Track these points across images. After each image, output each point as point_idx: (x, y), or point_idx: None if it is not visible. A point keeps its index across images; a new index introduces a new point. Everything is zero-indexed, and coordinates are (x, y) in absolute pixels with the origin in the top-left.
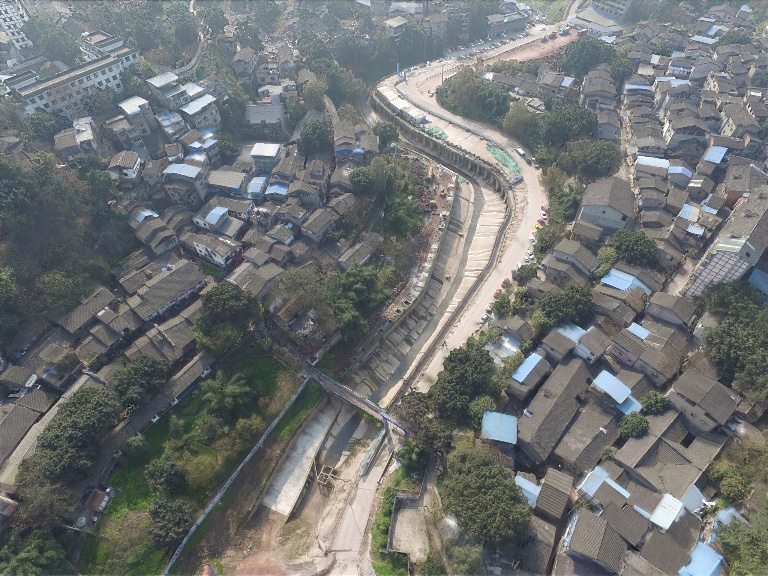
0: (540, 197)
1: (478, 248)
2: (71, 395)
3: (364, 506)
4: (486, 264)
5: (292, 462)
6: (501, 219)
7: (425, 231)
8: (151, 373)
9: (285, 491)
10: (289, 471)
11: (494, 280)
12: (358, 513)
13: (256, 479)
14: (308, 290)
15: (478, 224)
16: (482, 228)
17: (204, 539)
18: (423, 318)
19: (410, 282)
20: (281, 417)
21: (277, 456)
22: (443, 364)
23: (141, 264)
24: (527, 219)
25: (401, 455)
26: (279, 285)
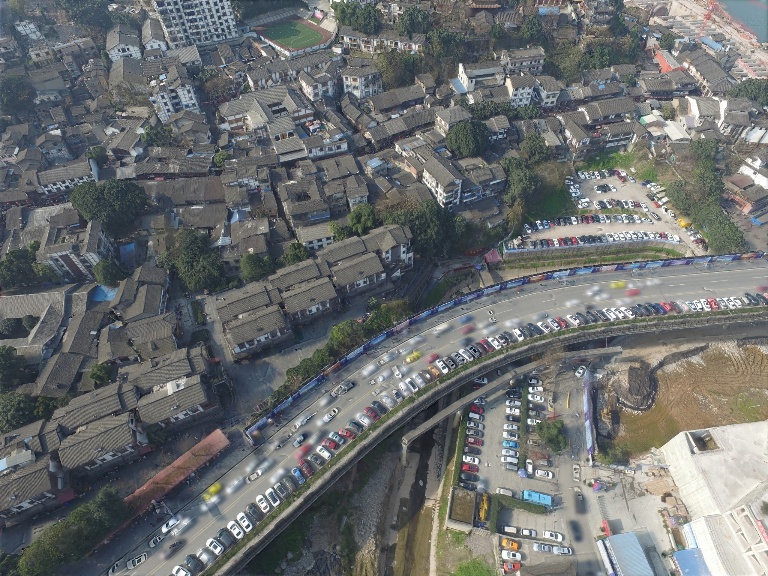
0: None
1: None
2: None
3: None
4: None
5: None
6: None
7: None
8: None
9: None
10: None
11: None
12: None
13: None
14: None
15: None
16: None
17: None
18: None
19: None
20: None
21: None
22: None
23: None
24: None
25: None
26: None
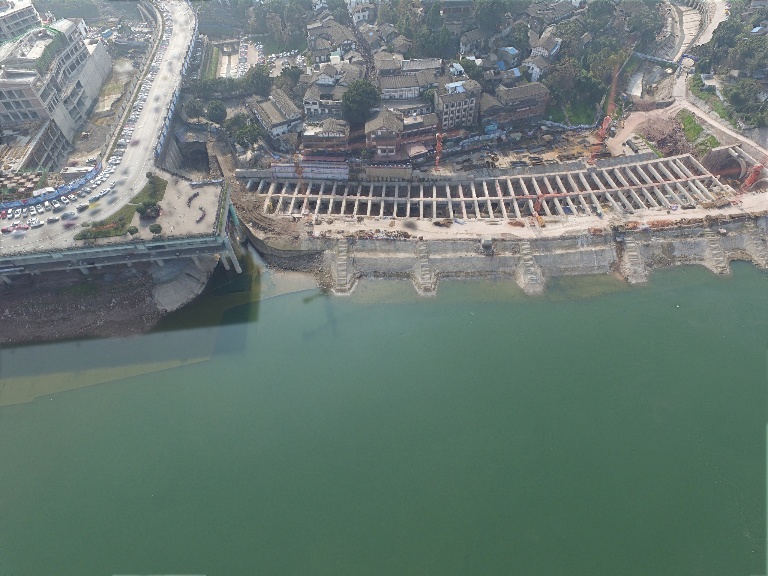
0: (722, 2)
1: (689, 26)
2: (550, 30)
3: (682, 85)
4: (697, 31)
5: (632, 84)
6: (698, 15)
7: (661, 14)
8: (579, 28)
9: (634, 90)
10: (632, 86)
11: (711, 27)
12: (680, 87)
13: (624, 81)
14: (642, 2)
15: (684, 19)
16: (687, 20)
17: (612, 93)
18: (671, 48)
19: (663, 30)
20: (625, 65)
21: (630, 75)
22: (714, 31)
23: (541, 1)
24: (719, 9)
25: (700, 62)
26: (617, 9)
